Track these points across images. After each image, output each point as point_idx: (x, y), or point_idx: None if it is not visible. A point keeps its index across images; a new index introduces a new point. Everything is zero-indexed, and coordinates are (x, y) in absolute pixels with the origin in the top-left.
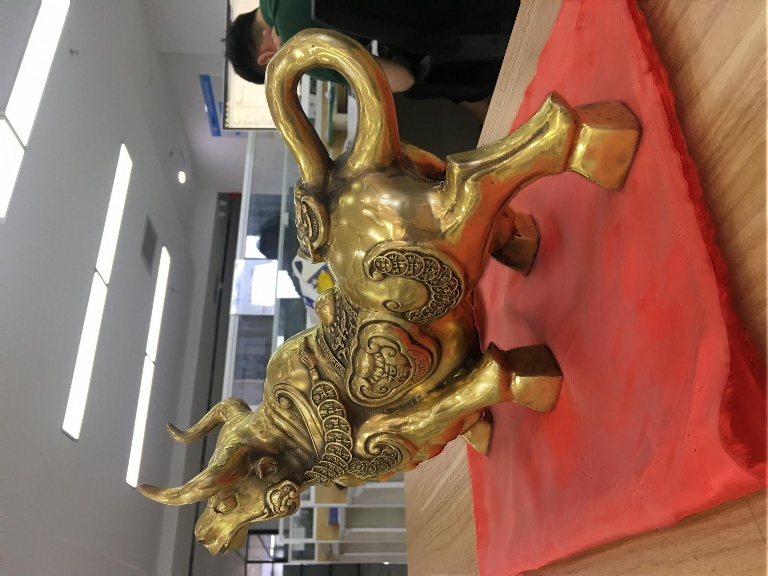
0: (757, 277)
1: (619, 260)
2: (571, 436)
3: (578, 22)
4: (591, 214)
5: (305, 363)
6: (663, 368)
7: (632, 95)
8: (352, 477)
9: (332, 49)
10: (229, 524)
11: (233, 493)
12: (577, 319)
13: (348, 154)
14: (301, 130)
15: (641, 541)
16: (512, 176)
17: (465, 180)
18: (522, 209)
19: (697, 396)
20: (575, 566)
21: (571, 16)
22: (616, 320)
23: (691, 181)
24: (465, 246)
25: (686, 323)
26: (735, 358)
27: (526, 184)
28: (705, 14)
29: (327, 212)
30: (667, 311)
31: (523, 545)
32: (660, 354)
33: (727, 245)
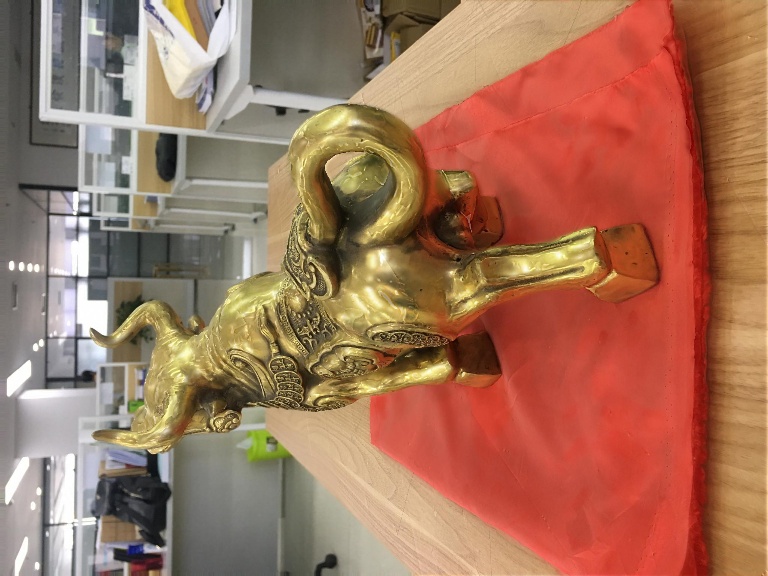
0: (725, 507)
1: (596, 360)
2: (499, 425)
3: (618, 83)
4: None
5: (265, 336)
6: (614, 479)
7: (660, 239)
8: None
9: (383, 147)
10: None
11: None
12: (531, 350)
13: (367, 222)
14: (323, 200)
15: None
16: (532, 292)
17: (489, 292)
18: (487, 183)
19: (650, 560)
20: None
21: (609, 57)
22: (576, 395)
23: (700, 402)
24: (466, 323)
25: (648, 470)
26: (692, 567)
27: None
28: (767, 265)
29: (338, 280)
30: (632, 443)
31: (433, 470)
32: (615, 466)
33: (710, 466)
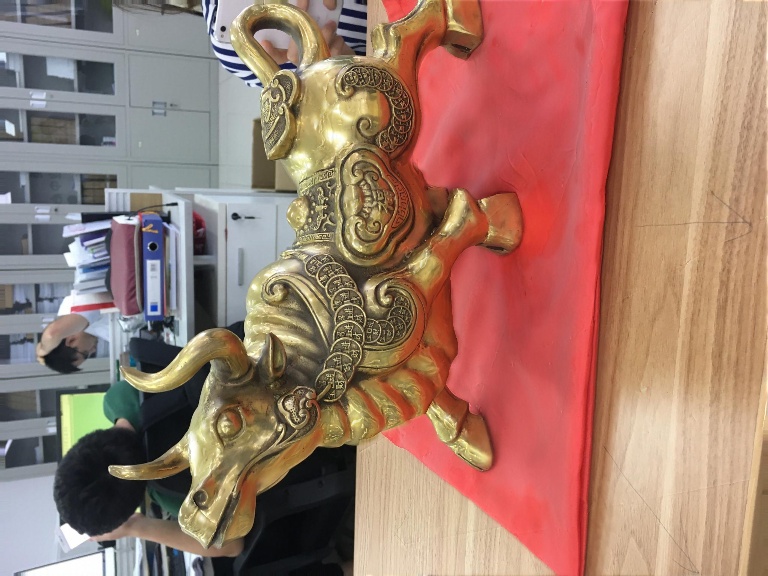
0: None
1: (505, 47)
2: (547, 197)
3: None
4: (474, 81)
5: (290, 257)
6: (564, 5)
7: None
8: (368, 399)
9: (277, 4)
10: (233, 465)
11: (236, 406)
12: (502, 141)
13: None
14: (262, 50)
15: (631, 90)
16: (417, 27)
17: (389, 29)
18: None
19: None
20: (618, 251)
21: None
22: (524, 73)
23: None
24: (404, 73)
25: None
26: None
27: (427, 42)
28: None
29: None
30: None
31: (571, 325)
32: (558, 9)
33: None
